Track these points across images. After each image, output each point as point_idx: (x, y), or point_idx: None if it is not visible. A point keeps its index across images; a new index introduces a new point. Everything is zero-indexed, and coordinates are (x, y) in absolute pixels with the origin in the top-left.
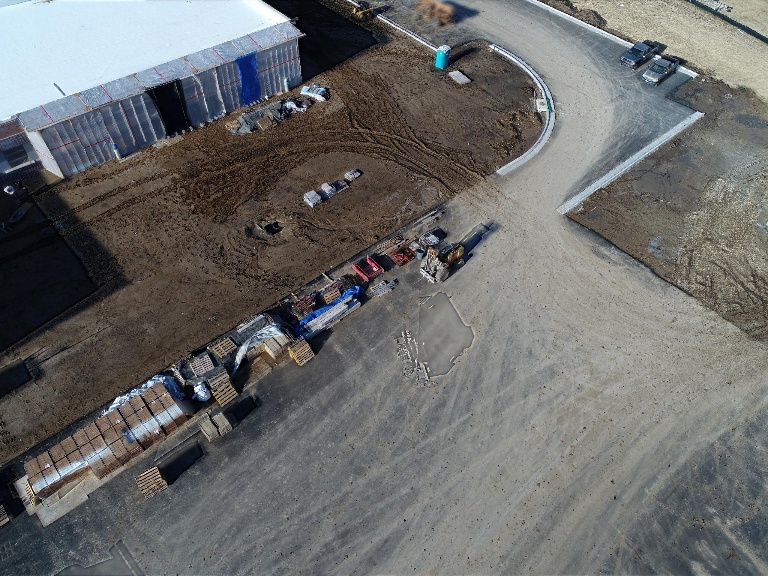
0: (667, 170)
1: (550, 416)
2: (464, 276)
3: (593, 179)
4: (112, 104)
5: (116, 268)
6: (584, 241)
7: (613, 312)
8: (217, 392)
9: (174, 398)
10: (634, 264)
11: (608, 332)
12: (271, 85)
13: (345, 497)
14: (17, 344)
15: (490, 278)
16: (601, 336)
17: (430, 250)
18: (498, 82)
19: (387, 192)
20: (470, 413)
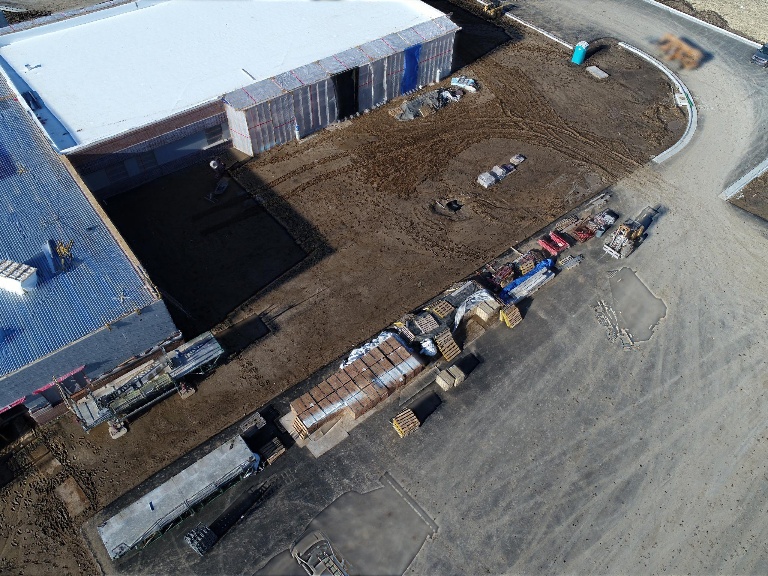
0: None
1: (755, 380)
2: (644, 253)
3: (747, 169)
4: (303, 88)
5: (320, 237)
6: (751, 225)
7: None
8: (444, 348)
9: None
10: None
11: None
12: (426, 75)
13: (581, 444)
14: (249, 301)
15: (669, 256)
16: None
17: (622, 227)
18: (635, 77)
19: (553, 176)
20: (679, 375)
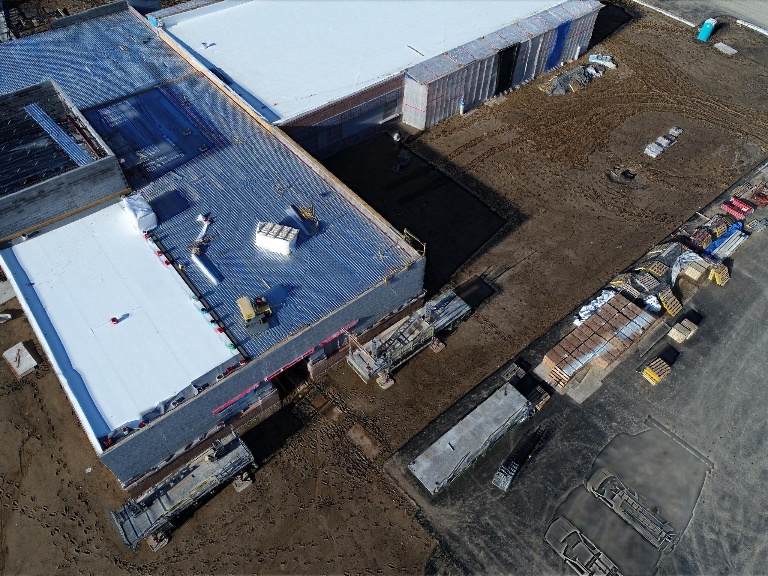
0: None
1: None
2: None
3: None
4: (476, 63)
5: (512, 205)
6: None
7: None
8: (668, 304)
9: None
10: None
11: None
12: (568, 52)
13: None
14: (466, 263)
15: None
16: None
17: None
18: (762, 53)
19: (714, 146)
20: None
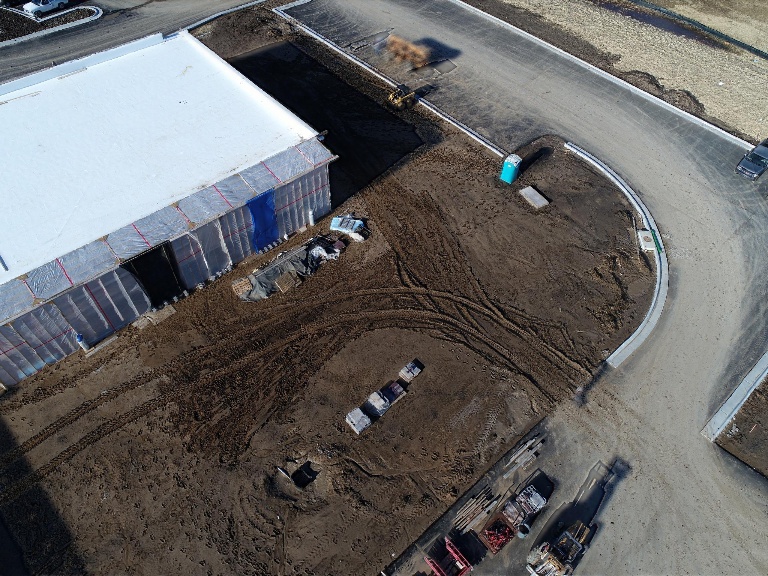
0: None
1: None
2: (591, 572)
3: (740, 373)
4: (72, 290)
5: (74, 568)
6: (752, 495)
7: None
8: None
9: None
10: None
11: None
12: (292, 221)
13: None
14: None
15: (630, 575)
16: None
17: (551, 561)
18: (584, 203)
19: (460, 402)
20: None
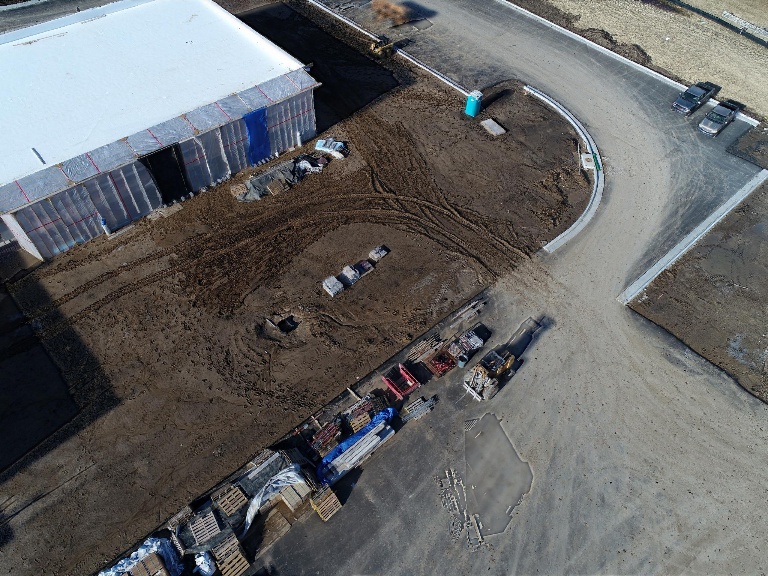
0: (738, 245)
1: None
2: (515, 390)
3: (655, 257)
4: (99, 177)
5: (102, 382)
6: (652, 341)
7: (696, 441)
8: (224, 565)
9: (171, 572)
10: (714, 373)
11: (693, 470)
12: (282, 140)
13: None
14: None
15: (546, 393)
16: (685, 475)
17: (478, 368)
18: (536, 132)
19: (419, 276)
20: None
